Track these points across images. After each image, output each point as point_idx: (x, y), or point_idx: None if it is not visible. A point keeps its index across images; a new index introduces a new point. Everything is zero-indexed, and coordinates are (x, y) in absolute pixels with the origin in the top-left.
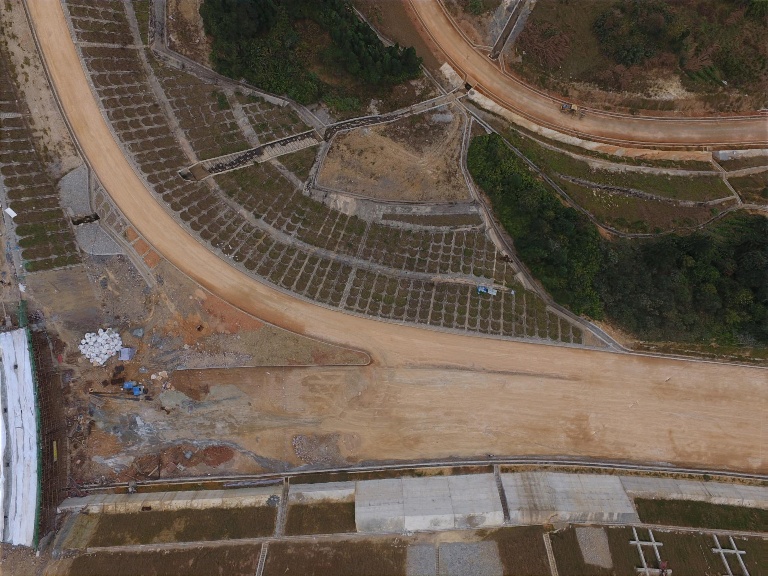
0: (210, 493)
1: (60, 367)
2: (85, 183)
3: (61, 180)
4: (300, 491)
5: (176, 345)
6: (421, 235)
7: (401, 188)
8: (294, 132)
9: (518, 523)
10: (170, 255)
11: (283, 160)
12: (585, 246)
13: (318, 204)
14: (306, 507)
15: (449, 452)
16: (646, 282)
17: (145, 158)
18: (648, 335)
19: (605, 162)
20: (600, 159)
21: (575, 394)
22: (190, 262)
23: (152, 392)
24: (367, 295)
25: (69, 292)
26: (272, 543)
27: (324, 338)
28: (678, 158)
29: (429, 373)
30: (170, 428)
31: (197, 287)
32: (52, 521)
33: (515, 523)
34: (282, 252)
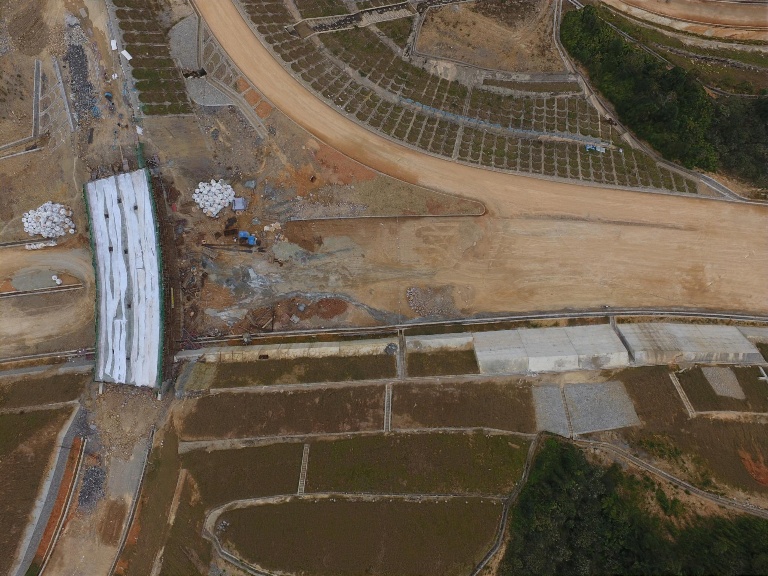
0: (326, 344)
1: (174, 216)
2: (194, 34)
3: (171, 29)
4: (417, 340)
5: (289, 196)
6: (523, 100)
7: (498, 58)
8: (389, 3)
9: (643, 363)
10: (282, 105)
11: (382, 26)
12: (695, 101)
13: (419, 69)
14: (424, 355)
15: (564, 304)
16: (761, 133)
17: (254, 10)
18: (767, 180)
19: (697, 39)
20: (692, 36)
21: (691, 245)
22: (302, 112)
23: (265, 243)
24: (478, 148)
25: (183, 140)
26: (396, 384)
27: (438, 189)
28: (767, 38)
29: (544, 224)
30: (283, 280)
31: (310, 137)
32: (170, 369)
33: (640, 363)
34: (389, 109)
